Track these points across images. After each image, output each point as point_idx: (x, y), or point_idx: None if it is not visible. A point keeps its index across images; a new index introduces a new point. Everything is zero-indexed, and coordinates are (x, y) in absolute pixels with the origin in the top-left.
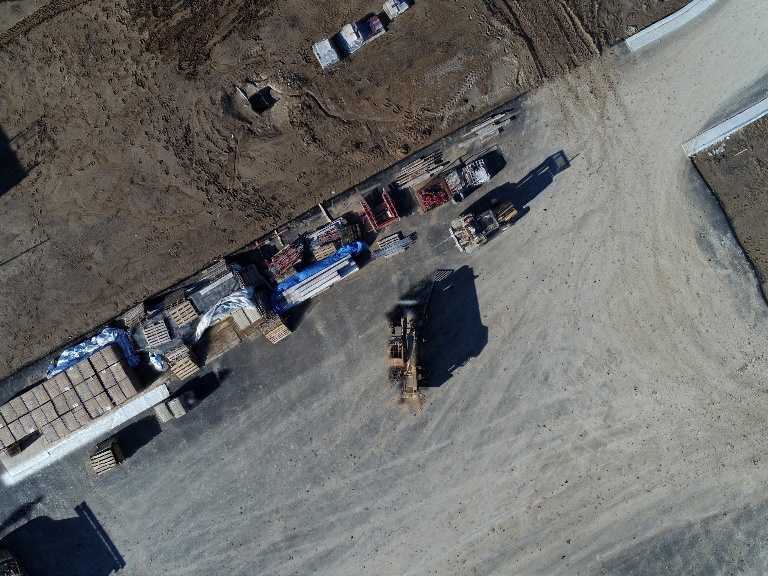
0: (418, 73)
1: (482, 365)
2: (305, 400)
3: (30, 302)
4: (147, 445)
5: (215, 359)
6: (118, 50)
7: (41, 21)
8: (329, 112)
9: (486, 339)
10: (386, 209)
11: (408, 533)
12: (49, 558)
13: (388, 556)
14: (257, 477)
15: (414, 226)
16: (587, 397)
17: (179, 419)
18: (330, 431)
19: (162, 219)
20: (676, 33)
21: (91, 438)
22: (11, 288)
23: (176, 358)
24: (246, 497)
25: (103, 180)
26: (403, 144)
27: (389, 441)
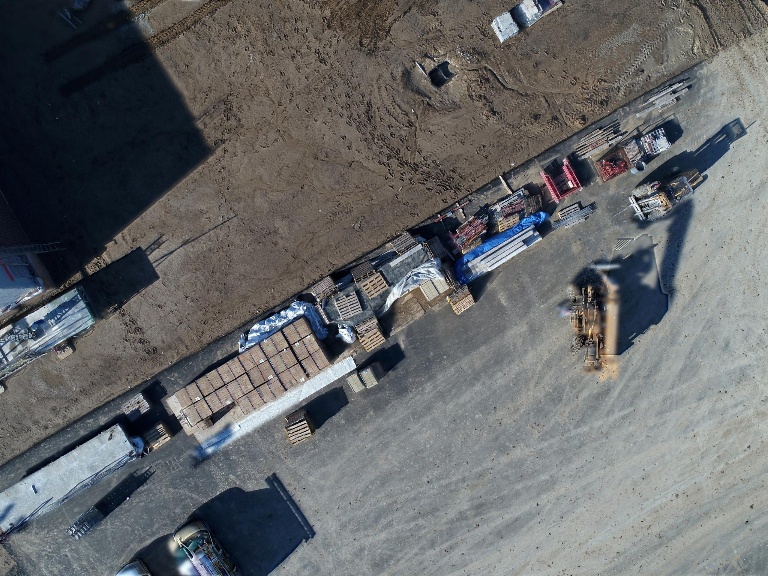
0: (594, 45)
1: (663, 332)
2: (489, 370)
3: (218, 278)
4: (335, 416)
5: (400, 331)
6: (301, 29)
7: (227, 2)
8: (507, 85)
9: (666, 306)
10: (566, 179)
11: (592, 500)
12: (241, 529)
13: (573, 523)
14: (443, 446)
15: (593, 196)
16: (767, 362)
17: (365, 390)
18: (514, 400)
19: (345, 194)
20: None
21: (280, 410)
22: (200, 264)
23: (365, 330)
24: (432, 466)
25: (288, 157)
26: (581, 115)
27: (572, 409)
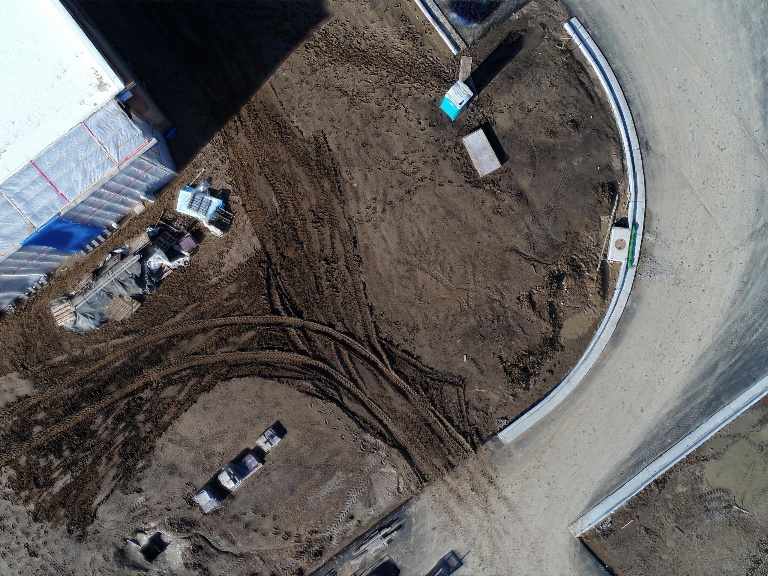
0: (301, 498)
1: None
2: None
3: None
4: None
5: None
6: (7, 526)
7: None
8: (220, 548)
9: None
10: None
11: None
12: None
13: None
14: None
15: None
16: None
17: None
18: None
19: None
20: (546, 419)
21: None
22: None
23: None
24: None
25: None
26: (297, 568)
27: None
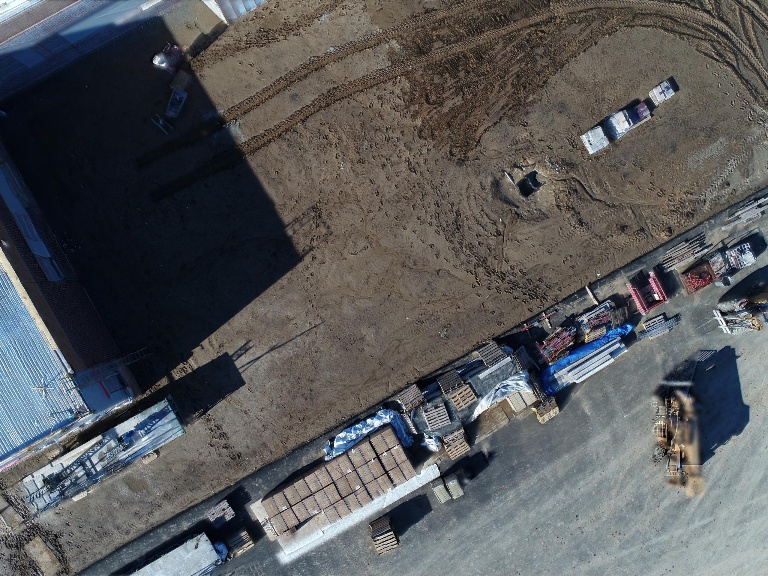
0: (681, 157)
1: (744, 443)
2: (571, 478)
3: (304, 384)
4: (418, 523)
5: (484, 439)
6: (391, 137)
7: (318, 109)
8: (594, 196)
9: (748, 418)
10: (652, 292)
11: None
12: None
13: None
14: (525, 554)
15: (678, 308)
16: None
17: None
18: (596, 509)
19: (432, 302)
20: None
21: (364, 517)
22: (286, 370)
23: (452, 440)
24: (514, 574)
25: (376, 264)
26: (667, 227)
27: (653, 518)
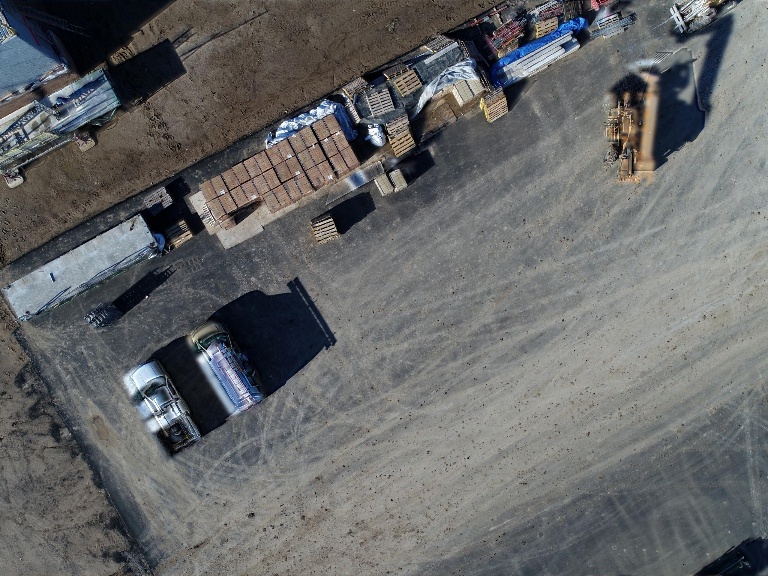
0: None
1: (698, 150)
2: (519, 181)
3: (247, 75)
4: (361, 222)
5: (431, 137)
6: None
7: None
8: None
9: (703, 124)
10: None
11: (619, 318)
12: (261, 333)
13: (598, 340)
14: (469, 257)
15: (634, 7)
16: None
17: (393, 197)
18: (543, 213)
19: None
20: None
21: (305, 213)
22: (229, 60)
23: (396, 131)
24: (458, 277)
25: None
26: None
27: (602, 224)
